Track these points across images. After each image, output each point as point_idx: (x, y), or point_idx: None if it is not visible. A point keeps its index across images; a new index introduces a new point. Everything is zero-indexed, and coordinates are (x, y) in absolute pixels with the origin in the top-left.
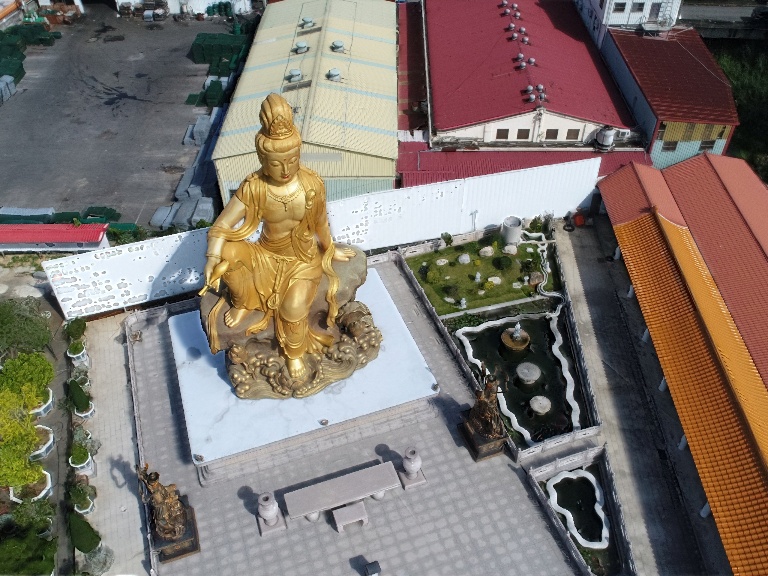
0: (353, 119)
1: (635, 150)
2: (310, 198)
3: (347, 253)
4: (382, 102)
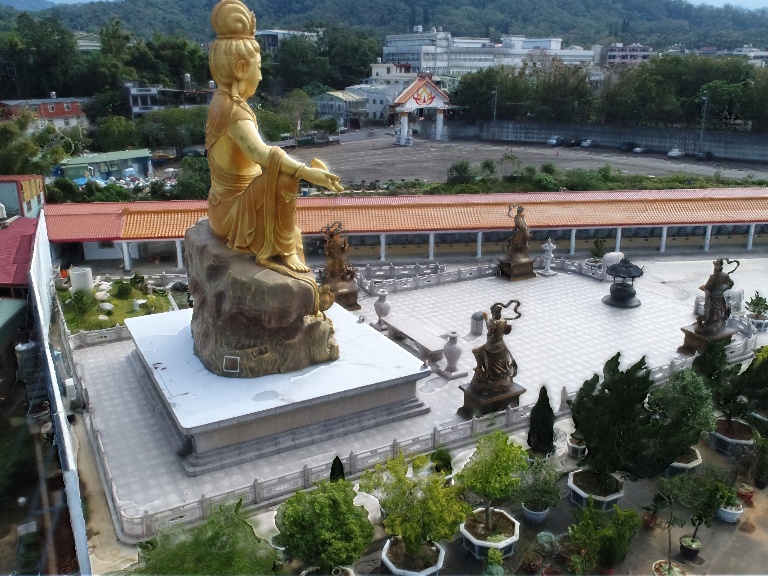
0: None
1: (16, 218)
2: None
3: None
4: None
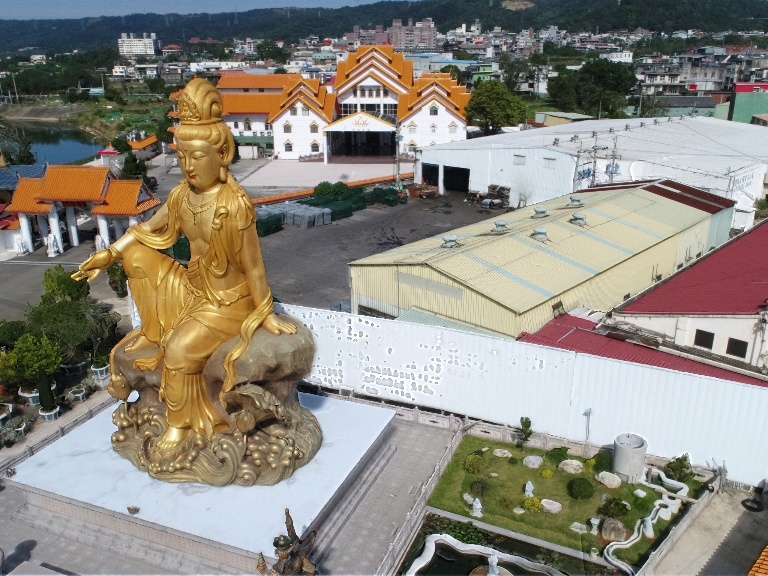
0: (513, 268)
1: None
2: (218, 215)
3: (283, 326)
4: (572, 269)
